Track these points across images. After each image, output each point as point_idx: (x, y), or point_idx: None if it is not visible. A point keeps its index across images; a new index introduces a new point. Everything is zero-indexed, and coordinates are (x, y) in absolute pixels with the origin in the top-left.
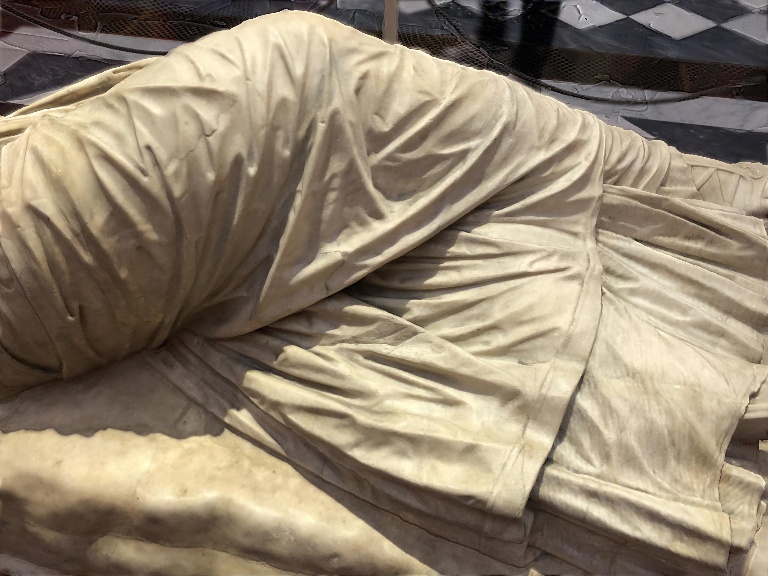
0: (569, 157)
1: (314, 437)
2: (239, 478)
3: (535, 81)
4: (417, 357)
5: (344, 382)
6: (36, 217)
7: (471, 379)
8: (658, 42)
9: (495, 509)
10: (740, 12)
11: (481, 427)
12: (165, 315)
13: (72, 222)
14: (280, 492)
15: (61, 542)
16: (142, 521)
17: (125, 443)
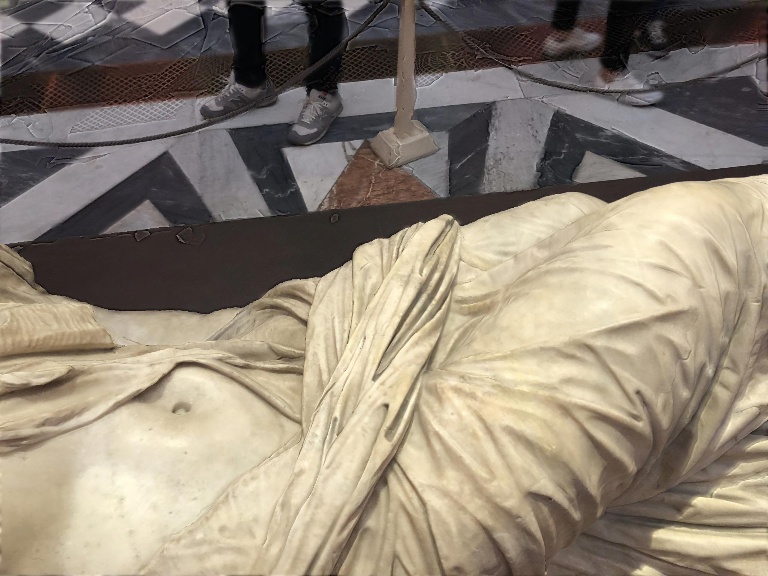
0: None
1: None
2: None
3: (573, 88)
4: None
5: None
6: (534, 501)
7: None
8: None
9: None
10: None
11: None
12: None
13: (569, 492)
14: None
15: None
16: None
17: None
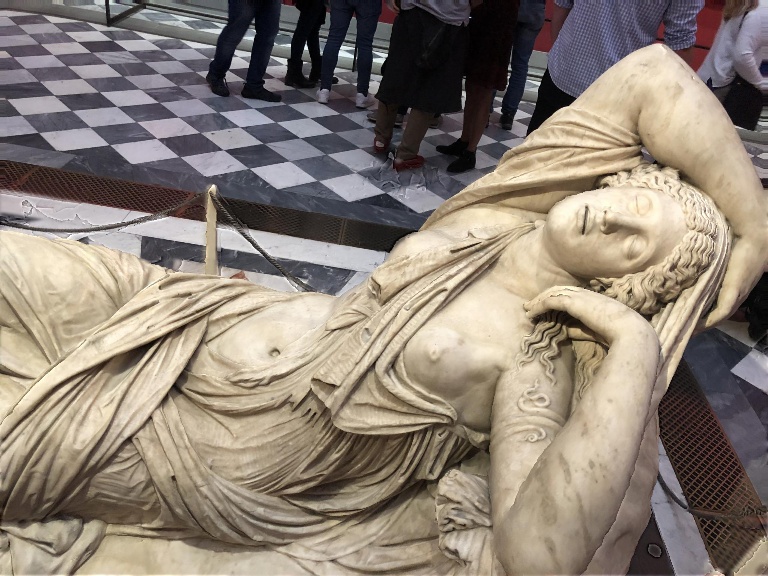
0: None
1: None
2: None
3: None
4: None
5: None
6: None
7: None
8: None
9: None
10: None
11: None
12: None
13: None
14: None
15: None
16: None
17: None
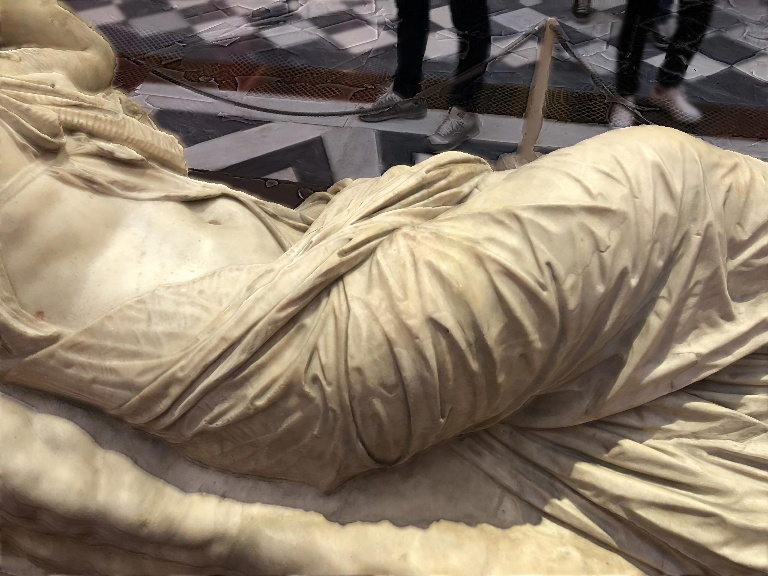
0: None
1: (671, 534)
2: (577, 570)
3: None
4: None
5: (696, 479)
6: (434, 329)
7: None
8: (765, 91)
9: None
10: None
11: None
12: (504, 411)
13: (468, 333)
14: None
15: None
16: None
17: (459, 535)
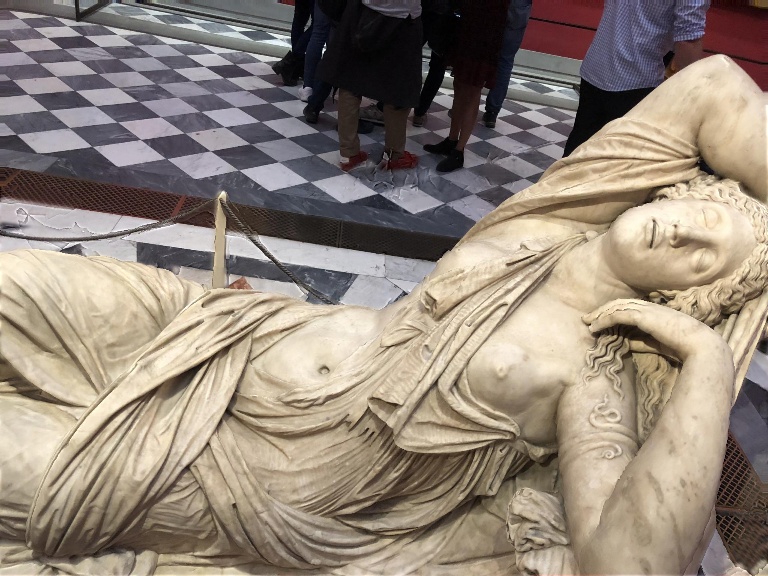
0: None
1: None
2: None
3: None
4: None
5: None
6: None
7: None
8: None
9: None
10: None
11: None
12: None
13: None
14: None
15: None
16: None
17: None
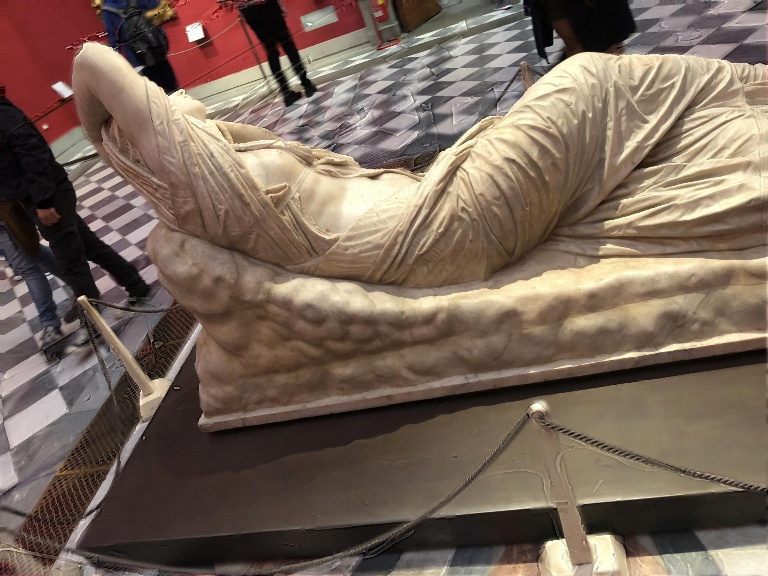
0: (719, 75)
1: (658, 225)
2: (624, 268)
3: None
4: (692, 172)
5: (661, 198)
6: (508, 163)
7: (724, 168)
8: None
9: (766, 198)
10: (753, 31)
11: (740, 181)
12: (558, 206)
13: (524, 159)
14: (648, 265)
15: (544, 332)
16: (586, 300)
17: (559, 274)
